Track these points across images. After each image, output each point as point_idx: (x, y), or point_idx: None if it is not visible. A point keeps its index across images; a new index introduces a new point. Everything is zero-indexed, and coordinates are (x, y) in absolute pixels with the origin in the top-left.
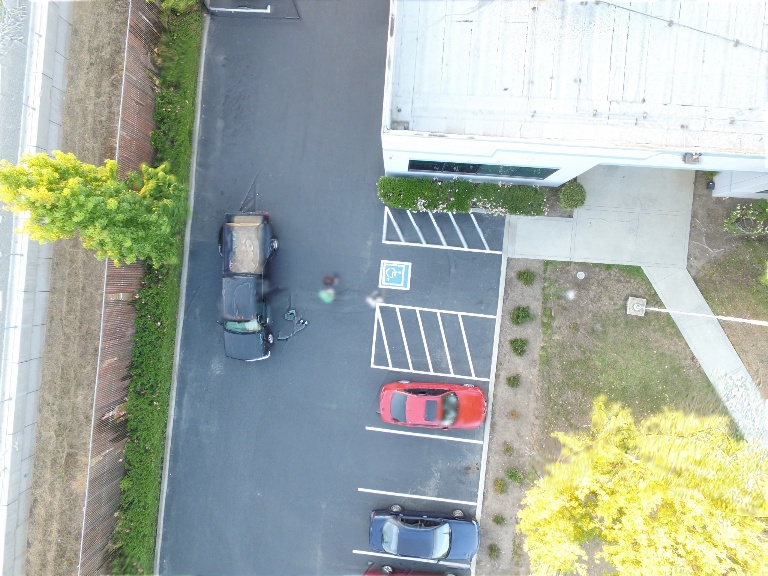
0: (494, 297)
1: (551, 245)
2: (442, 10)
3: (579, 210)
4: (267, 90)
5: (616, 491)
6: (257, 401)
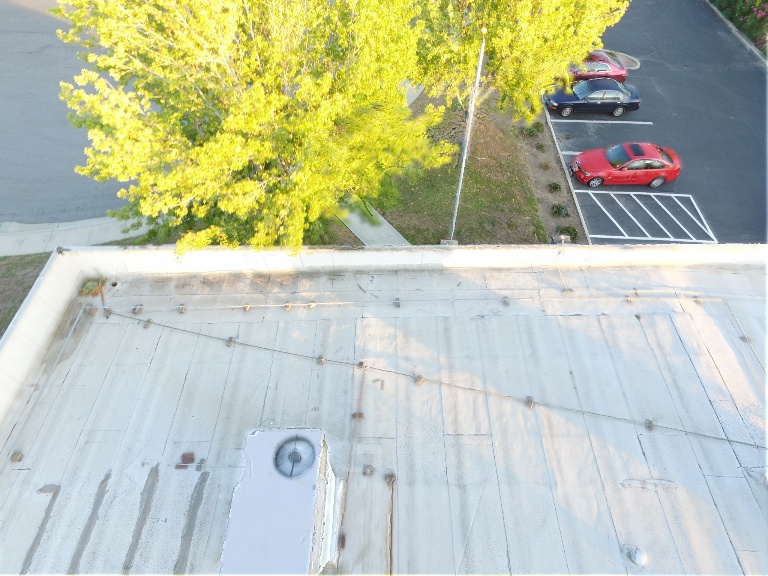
0: None
1: None
2: None
3: None
4: None
5: (447, 125)
6: None
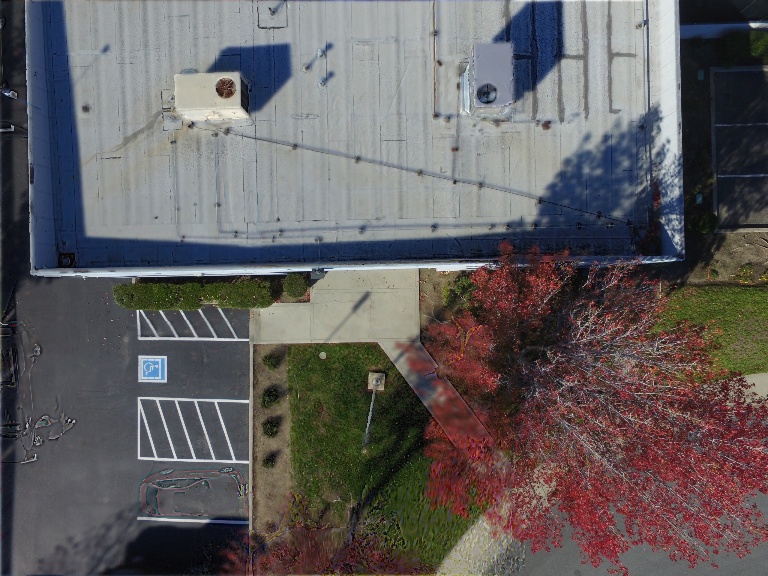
0: (246, 382)
1: (292, 329)
2: (93, 149)
3: (314, 294)
4: (18, 204)
5: (370, 561)
6: (33, 501)
